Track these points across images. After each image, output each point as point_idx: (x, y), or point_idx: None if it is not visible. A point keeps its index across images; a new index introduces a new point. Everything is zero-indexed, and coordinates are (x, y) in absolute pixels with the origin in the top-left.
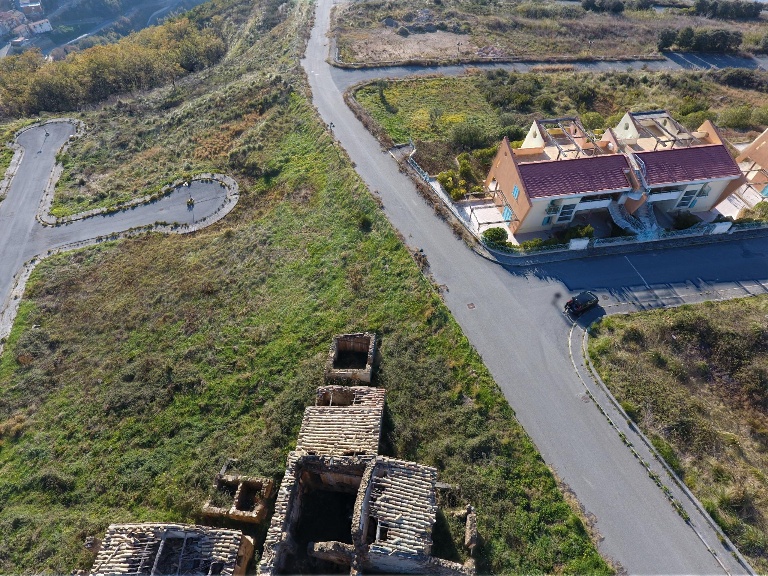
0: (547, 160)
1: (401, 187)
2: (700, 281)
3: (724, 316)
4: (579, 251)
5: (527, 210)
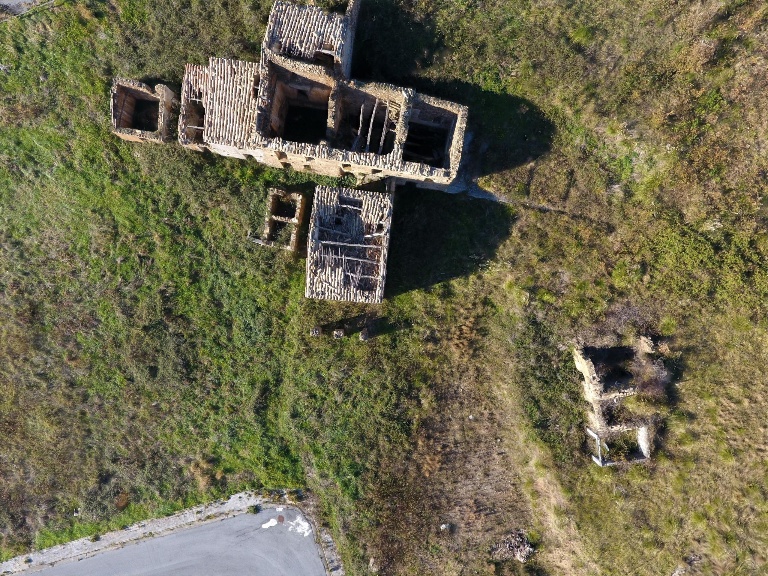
0: None
1: None
2: None
3: None
4: None
5: None
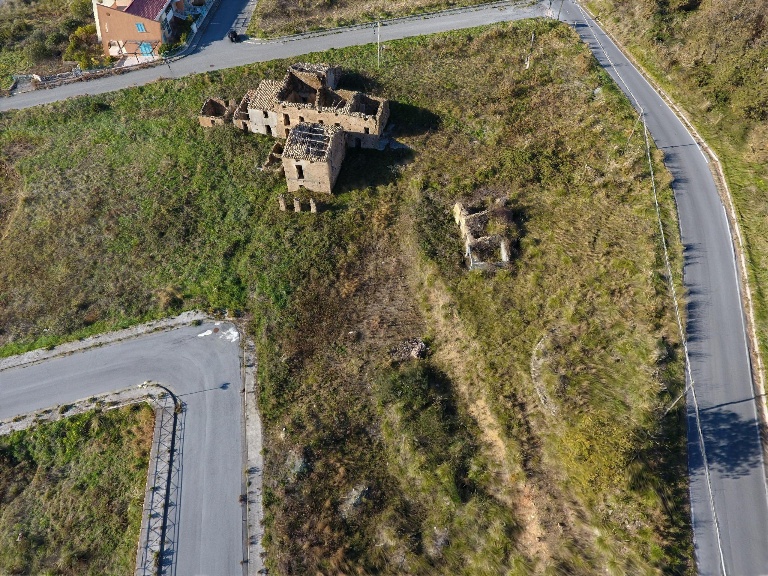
0: (129, 3)
1: (73, 88)
2: (240, 12)
3: (264, 8)
4: (198, 32)
5: (160, 27)
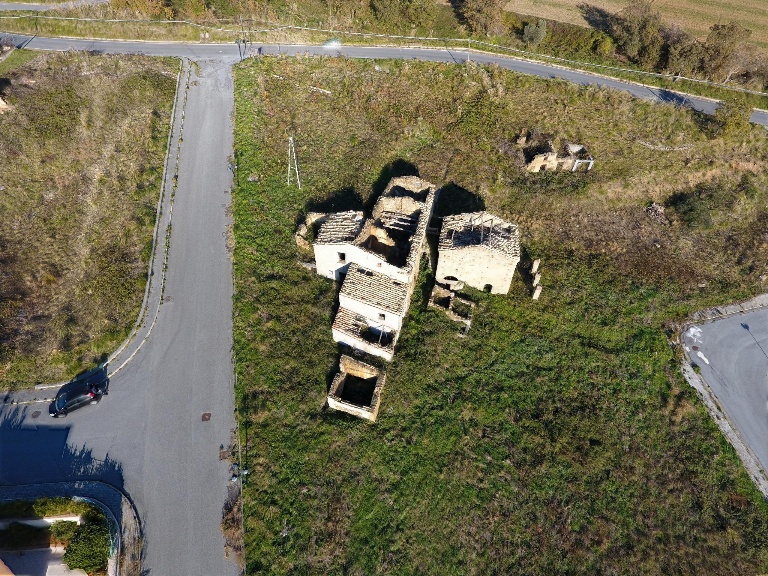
0: None
1: None
2: None
3: None
4: None
5: (3, 563)
